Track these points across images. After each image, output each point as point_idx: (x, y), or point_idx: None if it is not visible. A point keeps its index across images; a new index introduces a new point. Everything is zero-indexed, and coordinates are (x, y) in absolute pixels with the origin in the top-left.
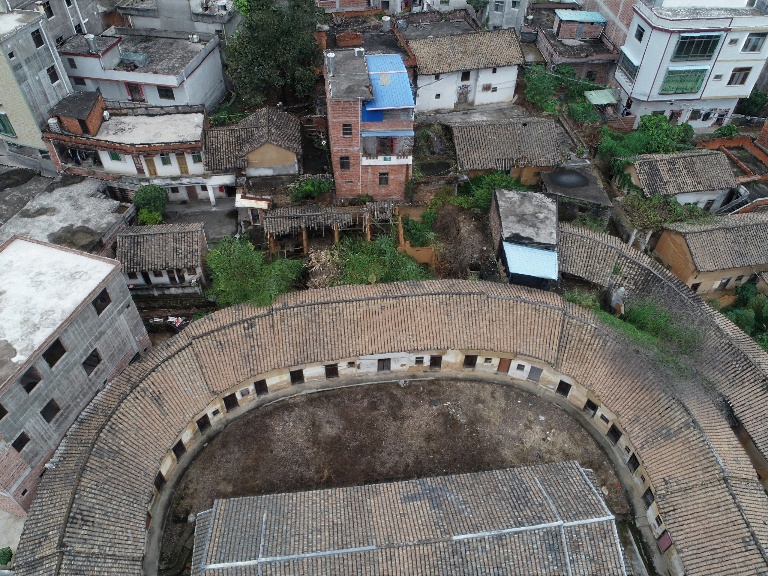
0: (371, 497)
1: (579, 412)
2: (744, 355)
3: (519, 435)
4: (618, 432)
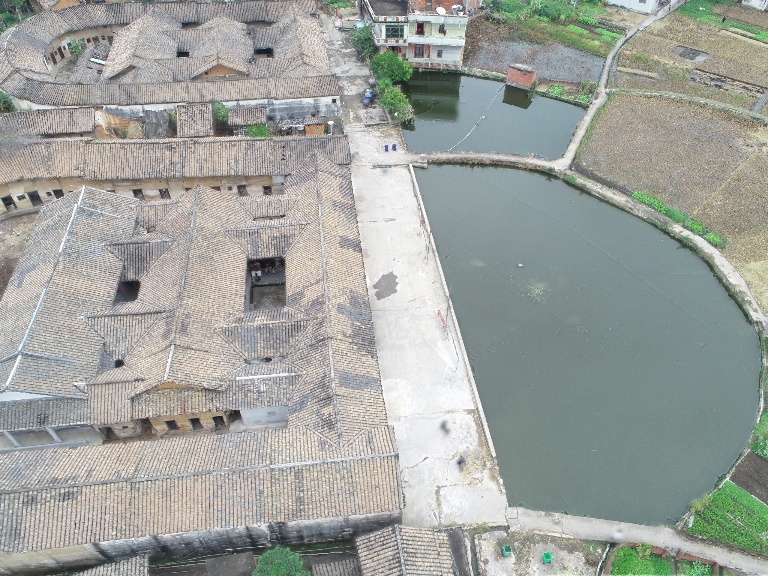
0: (6, 306)
1: (8, 214)
2: (17, 113)
3: (6, 246)
4: (34, 194)
